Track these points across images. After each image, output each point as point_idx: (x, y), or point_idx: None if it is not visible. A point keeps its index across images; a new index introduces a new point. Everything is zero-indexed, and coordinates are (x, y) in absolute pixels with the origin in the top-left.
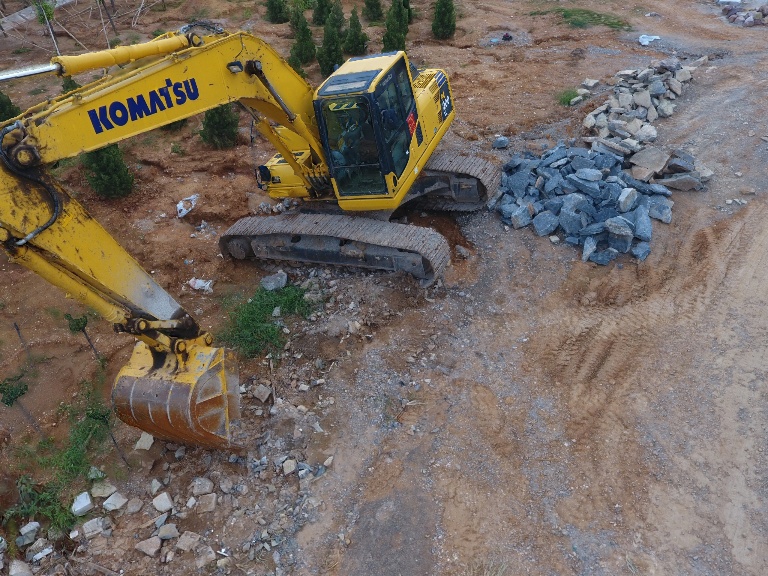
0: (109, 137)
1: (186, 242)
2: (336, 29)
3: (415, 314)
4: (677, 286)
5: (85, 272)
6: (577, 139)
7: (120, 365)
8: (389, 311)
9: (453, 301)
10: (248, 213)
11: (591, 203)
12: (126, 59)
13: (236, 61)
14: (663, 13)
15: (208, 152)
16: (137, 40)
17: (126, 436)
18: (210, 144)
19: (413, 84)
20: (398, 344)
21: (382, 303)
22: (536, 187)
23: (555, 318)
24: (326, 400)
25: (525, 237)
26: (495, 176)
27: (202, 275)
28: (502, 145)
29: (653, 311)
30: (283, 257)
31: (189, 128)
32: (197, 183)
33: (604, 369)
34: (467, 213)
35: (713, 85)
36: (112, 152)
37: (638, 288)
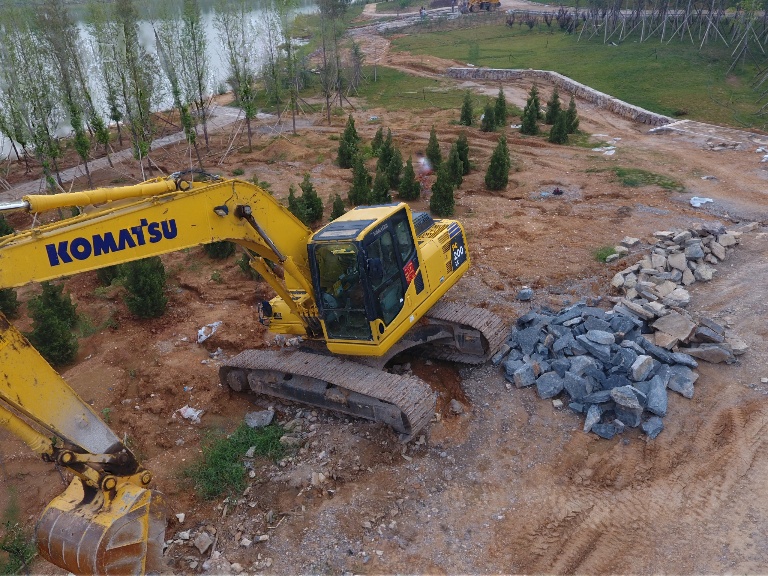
0: (65, 270)
1: (195, 368)
2: (393, 176)
3: (386, 472)
4: (689, 473)
5: (10, 398)
6: (603, 297)
7: None
8: (359, 465)
9: (432, 462)
10: (262, 344)
11: (600, 368)
12: (103, 200)
13: (224, 205)
14: (721, 177)
15: (243, 282)
16: None
17: (54, 572)
18: (248, 274)
19: (425, 233)
20: (359, 504)
21: (354, 455)
22: (545, 345)
23: (539, 495)
24: (264, 561)
25: (526, 398)
26: (501, 330)
27: (196, 404)
28: (525, 297)
29: (655, 500)
30: (275, 394)
31: (235, 258)
32: (224, 311)
33: (585, 566)
34: (470, 365)
35: (761, 252)
36: (150, 276)
37: (643, 470)
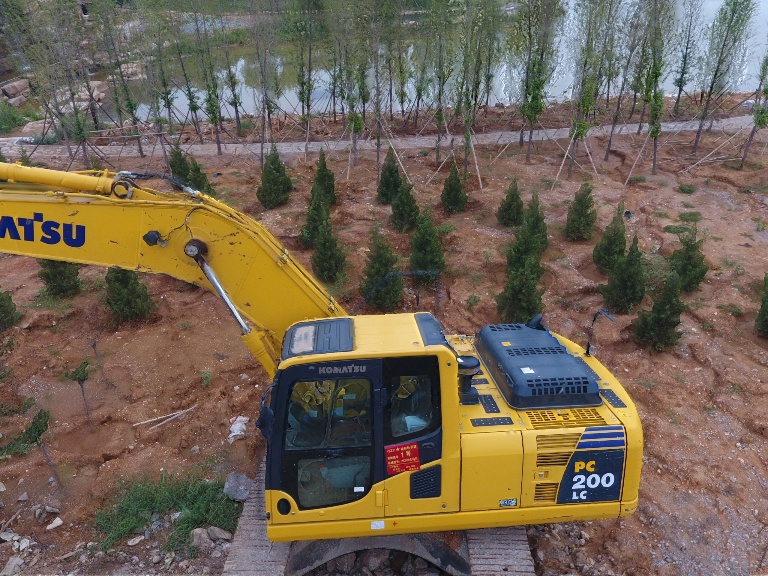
0: None
1: None
2: None
3: None
4: None
5: None
6: None
7: (105, 432)
8: None
9: None
10: None
11: None
12: (5, 177)
13: None
14: None
15: (485, 321)
16: (658, 186)
17: None
18: None
19: (548, 411)
20: None
21: None
22: None
23: None
24: None
25: None
26: None
27: None
28: None
29: None
30: None
31: None
32: None
33: None
34: None
35: None
36: None
37: None
